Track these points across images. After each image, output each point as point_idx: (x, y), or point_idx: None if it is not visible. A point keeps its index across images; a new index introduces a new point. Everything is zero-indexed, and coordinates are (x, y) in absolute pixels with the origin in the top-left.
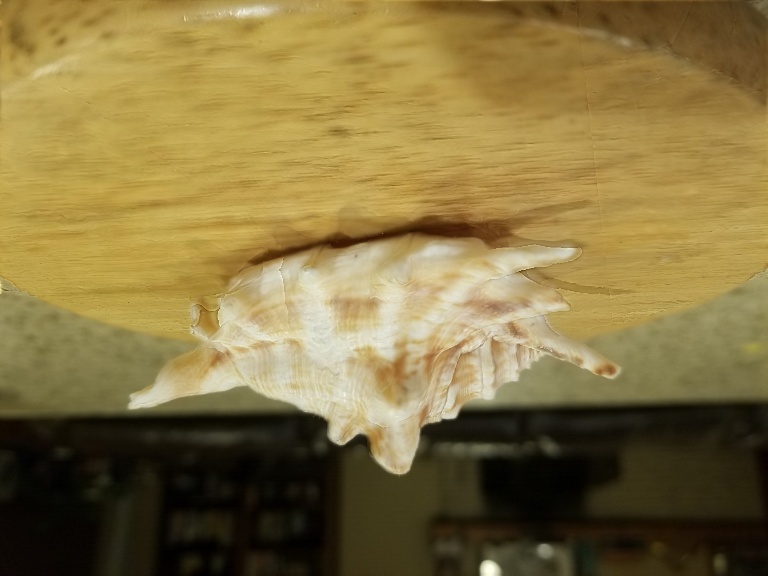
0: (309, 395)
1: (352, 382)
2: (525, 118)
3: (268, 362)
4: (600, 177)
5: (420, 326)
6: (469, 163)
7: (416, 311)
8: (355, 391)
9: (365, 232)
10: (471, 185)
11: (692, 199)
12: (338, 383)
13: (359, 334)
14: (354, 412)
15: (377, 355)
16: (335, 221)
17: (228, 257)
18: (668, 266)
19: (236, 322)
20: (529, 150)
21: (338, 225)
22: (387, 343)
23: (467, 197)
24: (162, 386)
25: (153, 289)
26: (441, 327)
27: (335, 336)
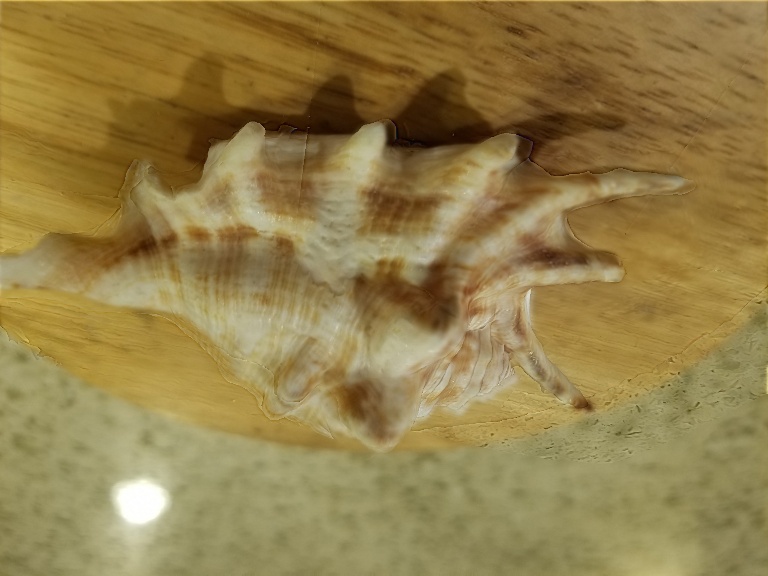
0: (284, 319)
1: (358, 309)
2: (725, 2)
3: (235, 261)
4: (697, 136)
5: (475, 249)
6: (623, 53)
7: (475, 230)
8: (360, 321)
9: (431, 128)
10: (594, 93)
11: (728, 207)
12: (335, 308)
13: (400, 238)
14: (334, 361)
15: (406, 277)
16: (411, 96)
17: (213, 118)
18: (624, 317)
19: (239, 171)
20: (686, 58)
21: (408, 105)
22: (431, 260)
23: (571, 114)
24: (35, 257)
25: (34, 150)
26: (492, 261)
27: (360, 238)
